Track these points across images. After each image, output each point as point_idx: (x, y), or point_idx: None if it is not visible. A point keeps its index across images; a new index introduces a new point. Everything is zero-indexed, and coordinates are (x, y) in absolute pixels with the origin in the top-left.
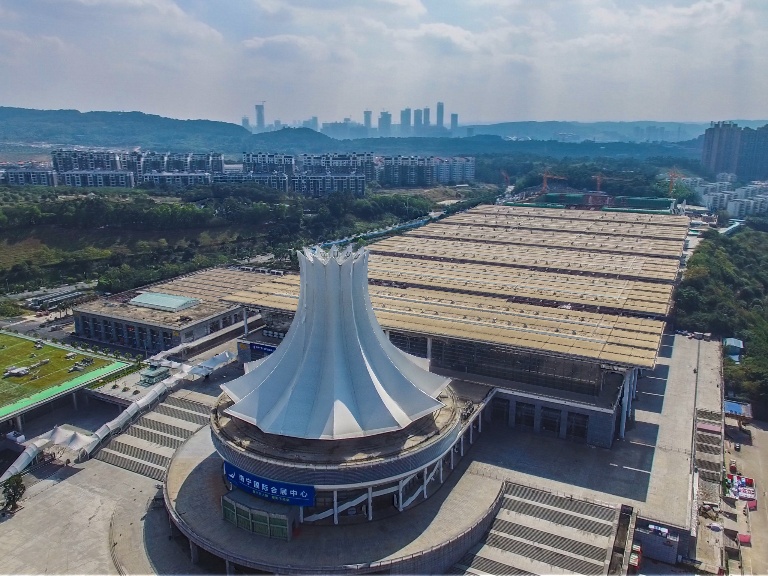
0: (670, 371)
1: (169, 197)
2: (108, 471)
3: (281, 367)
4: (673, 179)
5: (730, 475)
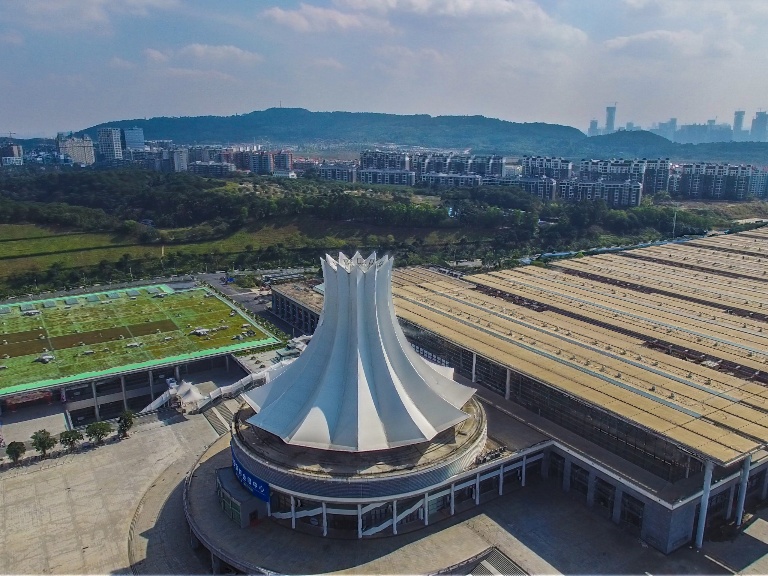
0: None
1: (436, 197)
2: (202, 426)
3: (296, 365)
4: None
5: None
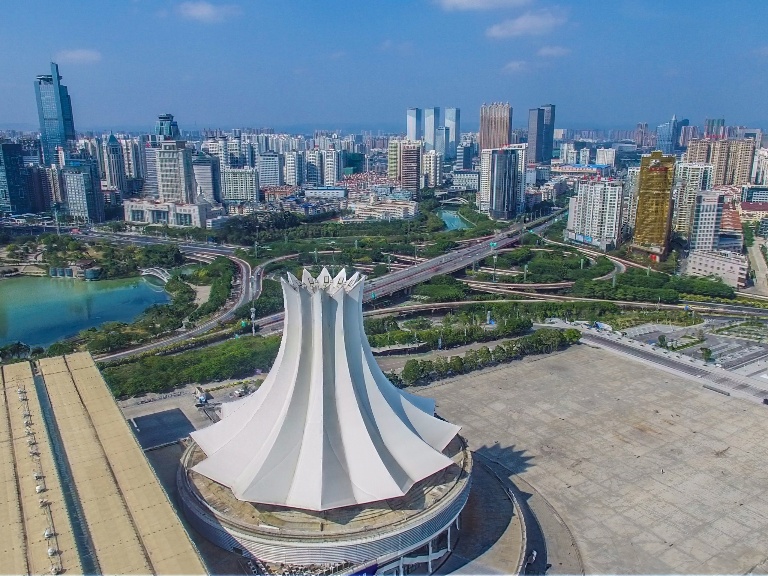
0: None
1: None
2: None
3: None
4: None
5: None
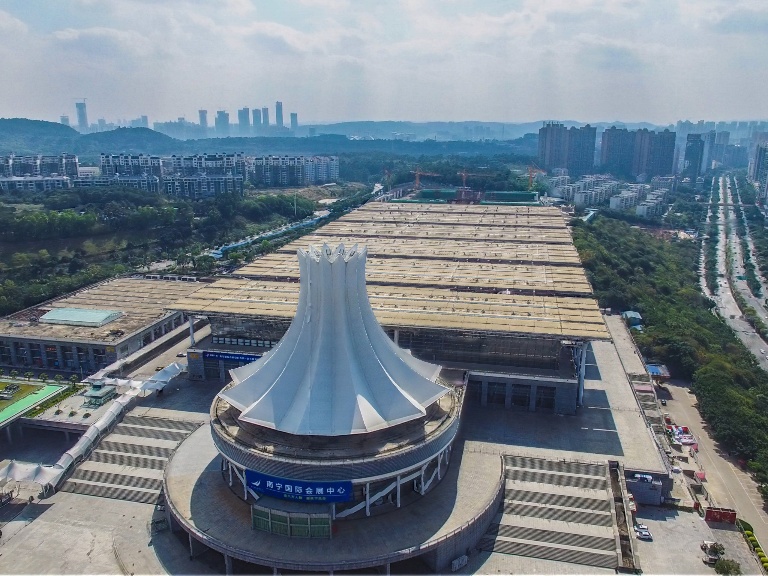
0: (592, 344)
1: (25, 204)
2: (84, 502)
3: (290, 369)
4: (532, 174)
5: (669, 426)
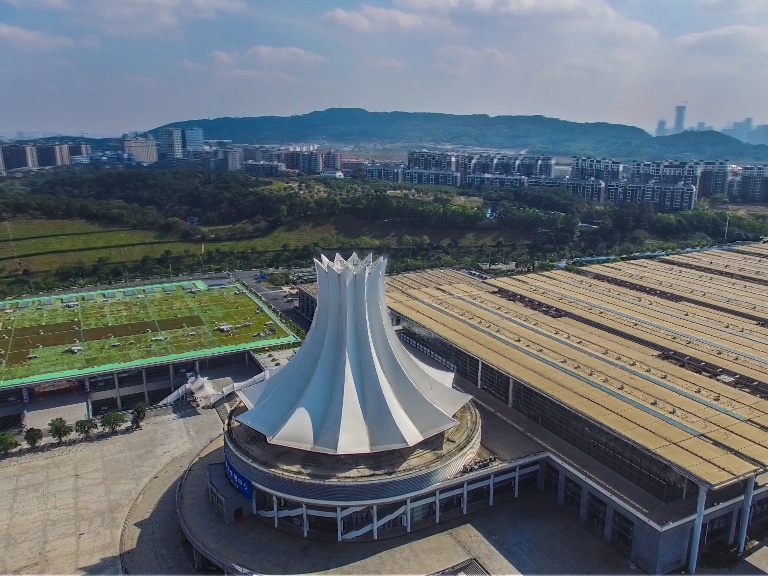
0: None
1: (479, 198)
2: (212, 421)
3: (290, 364)
4: None
5: None
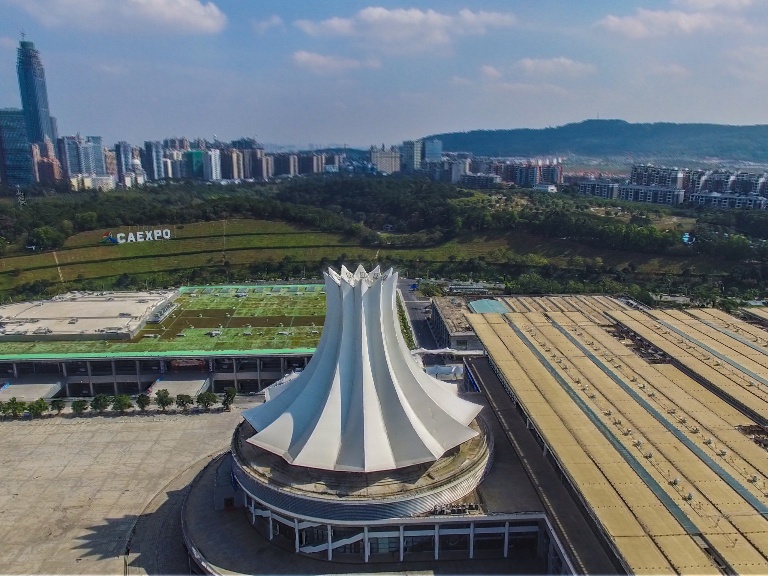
0: None
1: None
2: None
3: None
4: None
5: None
